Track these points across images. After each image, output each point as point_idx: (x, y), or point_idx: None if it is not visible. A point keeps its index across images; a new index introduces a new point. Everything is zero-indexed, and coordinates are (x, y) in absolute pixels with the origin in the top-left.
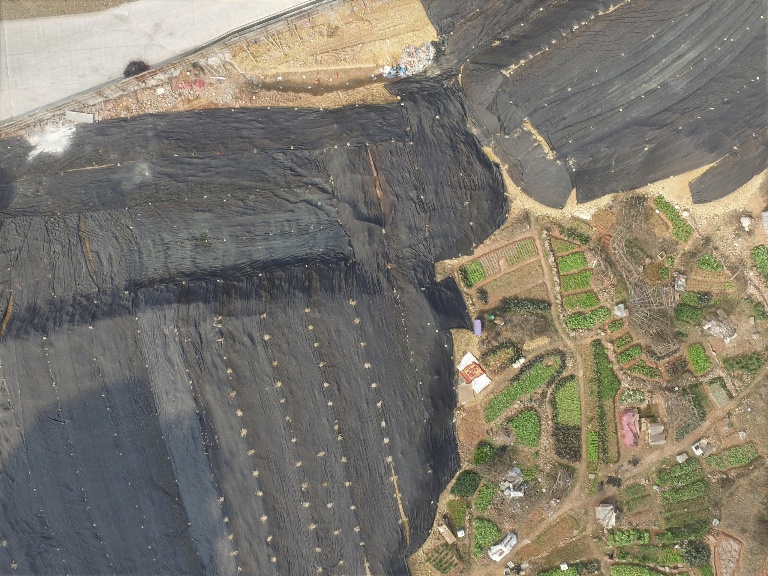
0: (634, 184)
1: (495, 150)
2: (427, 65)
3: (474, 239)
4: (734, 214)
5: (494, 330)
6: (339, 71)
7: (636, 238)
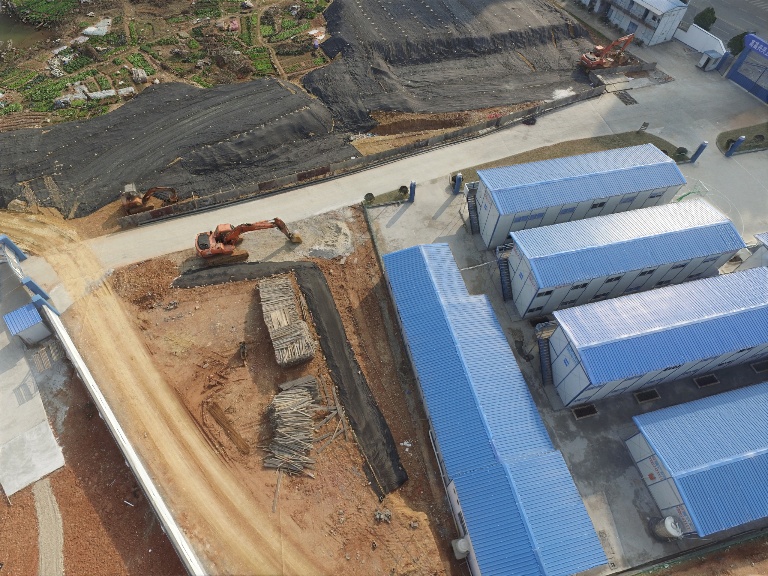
0: None
1: (310, 96)
2: None
3: None
4: None
5: (308, 42)
6: None
7: None
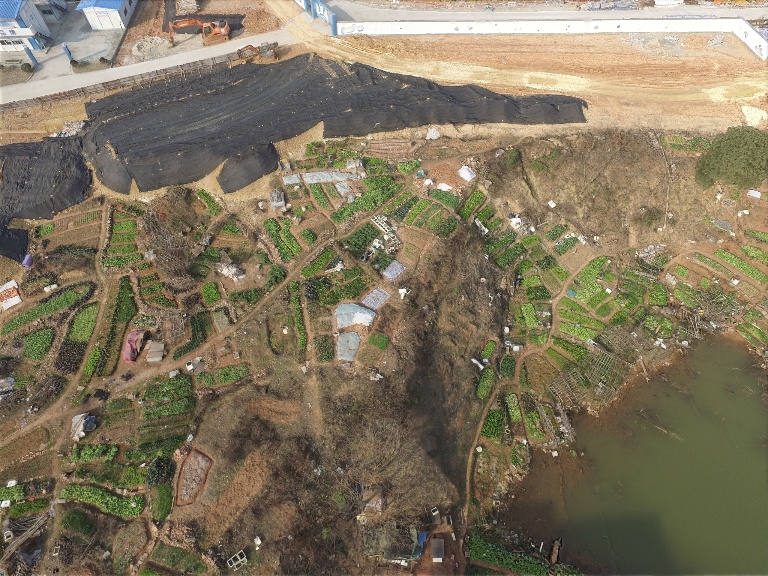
0: (181, 180)
1: (93, 163)
2: (78, 131)
3: (54, 208)
4: (255, 200)
5: (37, 261)
6: (24, 135)
7: (183, 216)
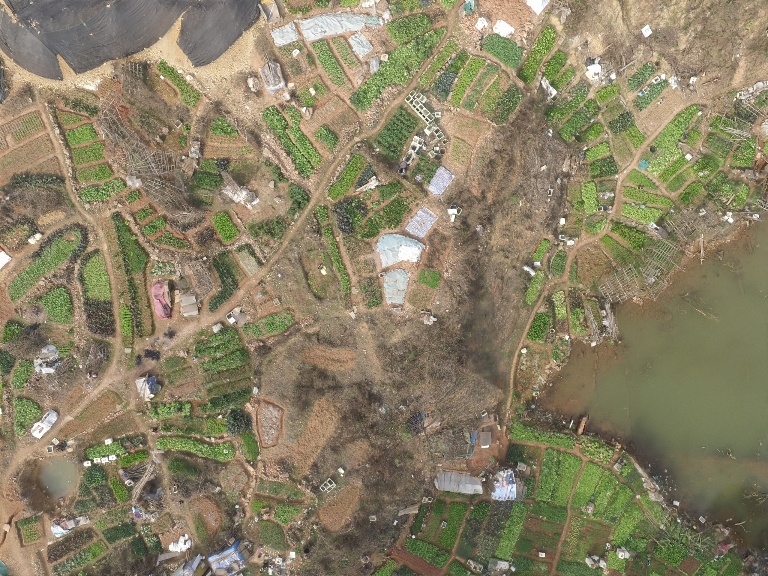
0: (127, 49)
1: None
2: None
3: None
4: (240, 76)
5: None
6: None
7: (150, 108)
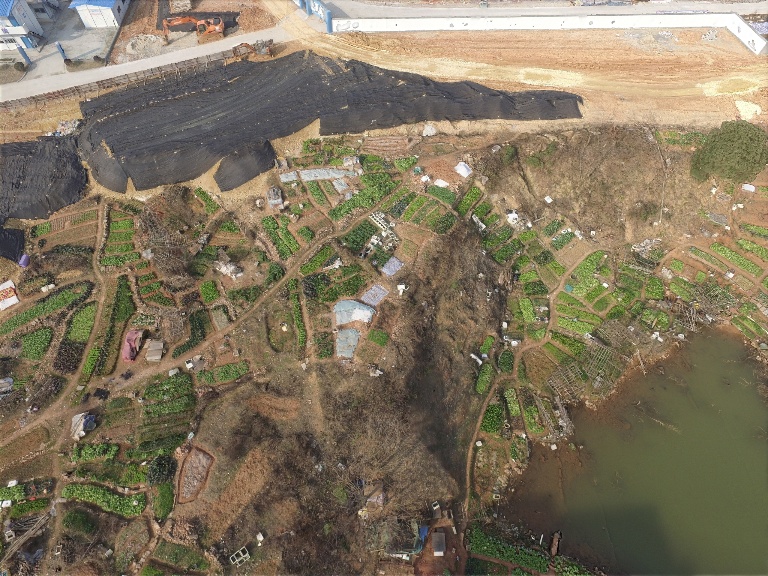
0: (178, 179)
1: (88, 162)
2: (73, 130)
3: (50, 207)
4: (252, 198)
5: (34, 261)
6: (19, 135)
7: (180, 214)
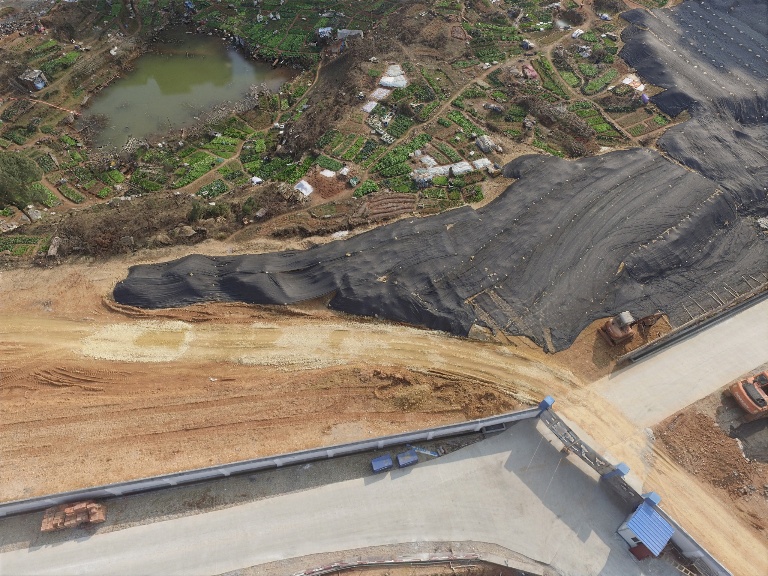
0: None
1: None
2: None
3: None
4: None
5: None
6: None
7: None
